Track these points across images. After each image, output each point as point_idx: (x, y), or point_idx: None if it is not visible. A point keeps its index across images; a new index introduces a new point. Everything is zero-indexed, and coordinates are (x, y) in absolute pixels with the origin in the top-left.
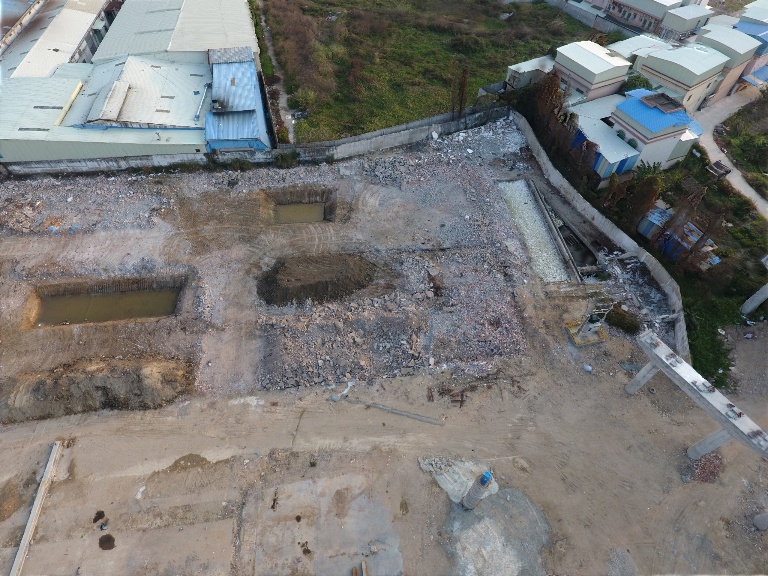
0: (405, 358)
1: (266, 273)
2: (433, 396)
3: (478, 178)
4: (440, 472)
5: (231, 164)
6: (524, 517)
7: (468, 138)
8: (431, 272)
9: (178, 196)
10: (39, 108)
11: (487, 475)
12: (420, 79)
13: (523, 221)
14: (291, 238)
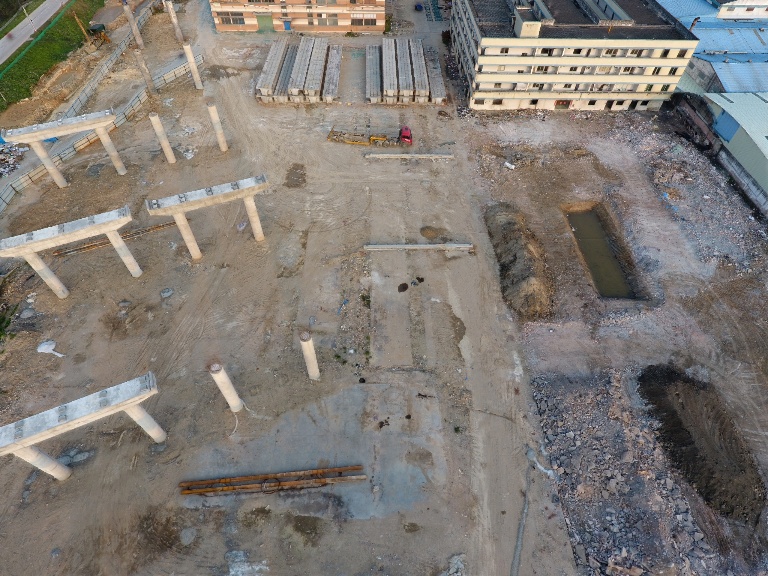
0: (600, 553)
1: (682, 372)
2: None
3: None
4: None
5: None
6: None
7: None
8: None
9: (760, 274)
10: None
11: None
12: None
13: None
14: (754, 399)
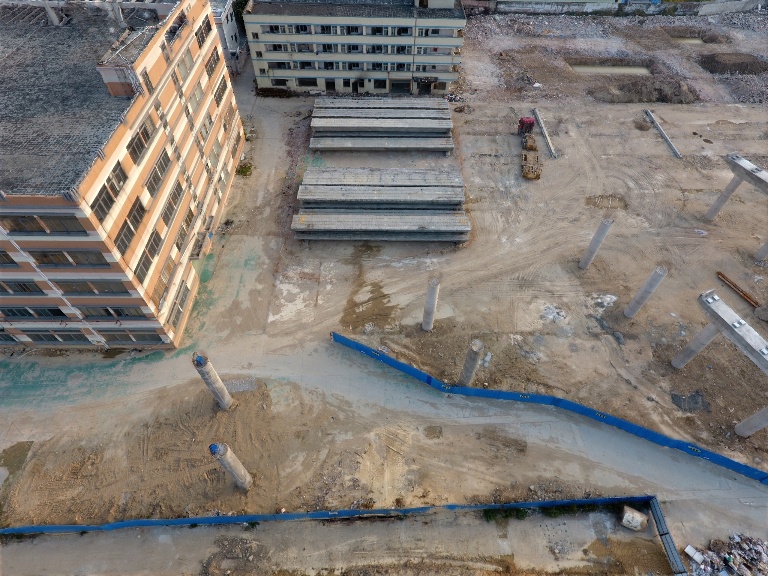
0: None
1: (701, 60)
2: None
3: None
4: None
5: (634, 12)
6: None
7: None
8: None
9: (612, 25)
10: None
11: None
12: None
13: None
14: (702, 48)
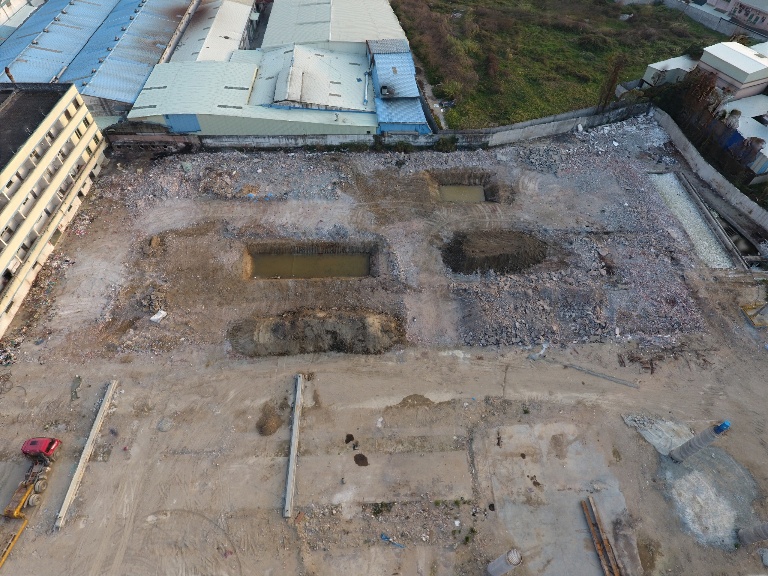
0: (592, 327)
1: (448, 244)
2: (624, 362)
3: (629, 169)
4: (644, 428)
5: (396, 146)
6: (731, 473)
7: (612, 132)
8: (601, 252)
9: (354, 172)
10: (229, 88)
11: (727, 423)
12: (555, 75)
13: (679, 211)
14: (463, 215)
